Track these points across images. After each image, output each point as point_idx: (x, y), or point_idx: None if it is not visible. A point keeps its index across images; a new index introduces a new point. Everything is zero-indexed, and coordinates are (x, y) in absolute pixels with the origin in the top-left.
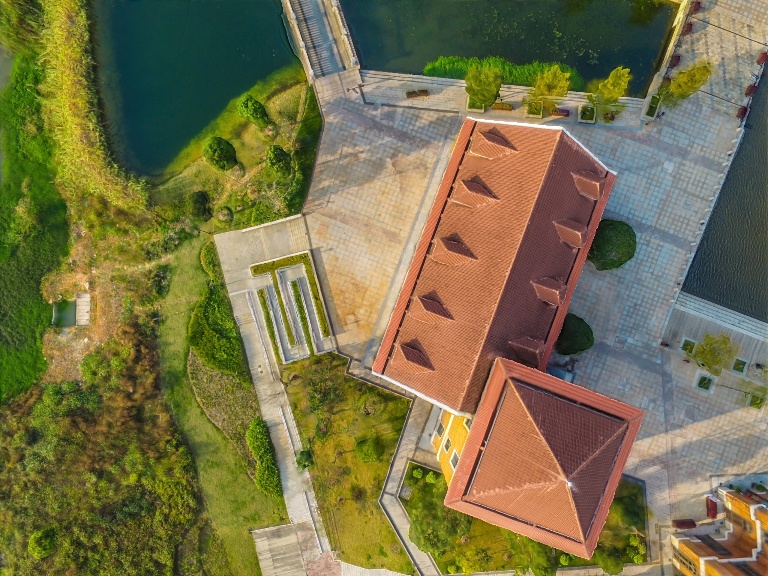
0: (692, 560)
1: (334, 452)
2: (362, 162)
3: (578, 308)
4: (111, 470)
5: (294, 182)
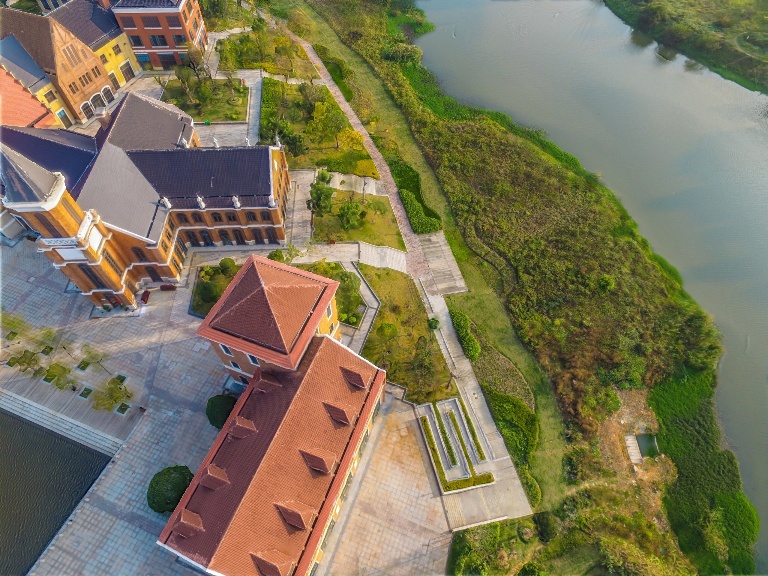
0: (173, 265)
1: (414, 336)
2: None
3: (208, 441)
4: (574, 328)
5: (463, 568)
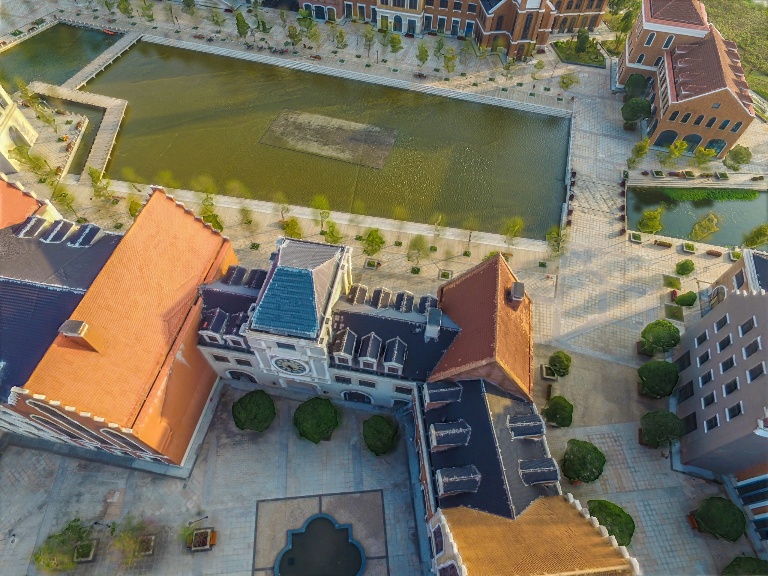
0: None
1: None
2: (766, 153)
3: None
4: None
5: None
